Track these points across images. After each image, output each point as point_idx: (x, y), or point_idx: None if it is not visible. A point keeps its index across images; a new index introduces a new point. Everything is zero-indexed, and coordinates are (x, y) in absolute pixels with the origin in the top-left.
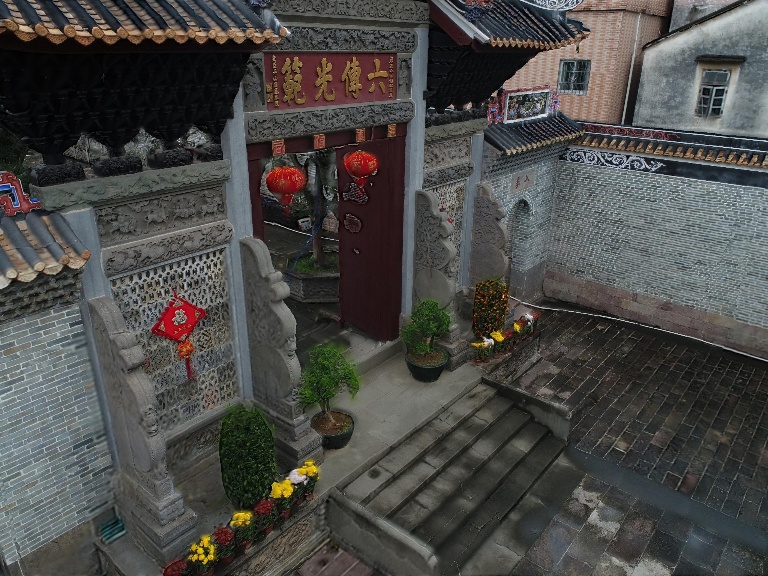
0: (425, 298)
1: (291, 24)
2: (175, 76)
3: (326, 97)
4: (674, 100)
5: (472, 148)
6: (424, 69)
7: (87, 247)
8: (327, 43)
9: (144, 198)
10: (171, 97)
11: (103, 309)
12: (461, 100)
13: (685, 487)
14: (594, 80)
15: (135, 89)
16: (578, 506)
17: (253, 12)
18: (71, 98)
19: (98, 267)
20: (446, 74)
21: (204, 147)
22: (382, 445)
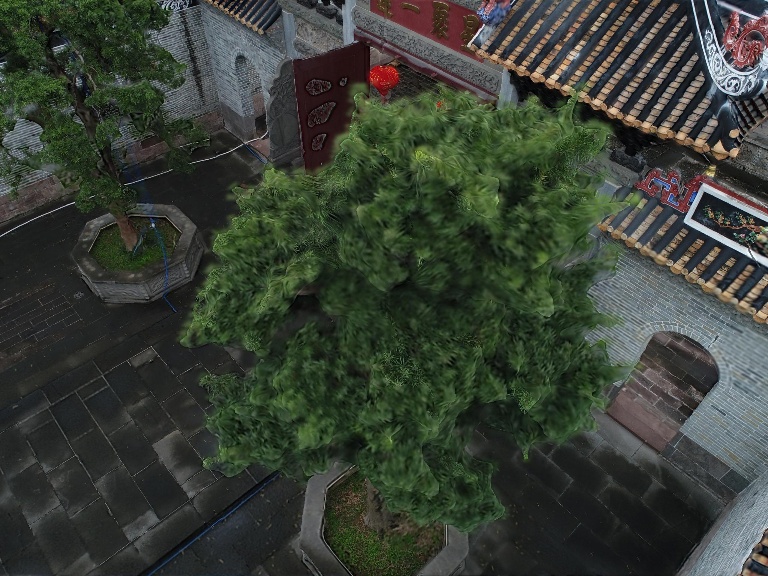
0: None
1: None
2: None
3: None
4: None
5: None
6: None
7: None
8: None
9: None
10: None
11: None
12: None
13: None
14: None
15: None
16: None
17: None
18: None
19: None
20: None
21: None
22: None
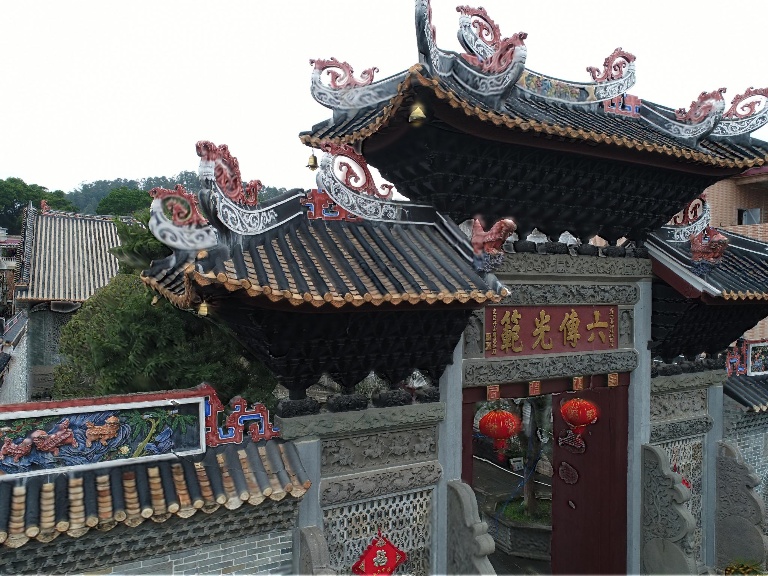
0: (657, 575)
1: (512, 282)
2: (405, 328)
3: (543, 346)
4: None
5: (709, 401)
6: (648, 320)
7: (309, 476)
8: (546, 297)
9: (365, 434)
10: (400, 346)
11: (312, 540)
12: (692, 350)
13: None
14: None
15: (371, 339)
16: None
17: (478, 276)
18: (320, 346)
19: (315, 496)
20: (673, 325)
21: (423, 389)
22: None
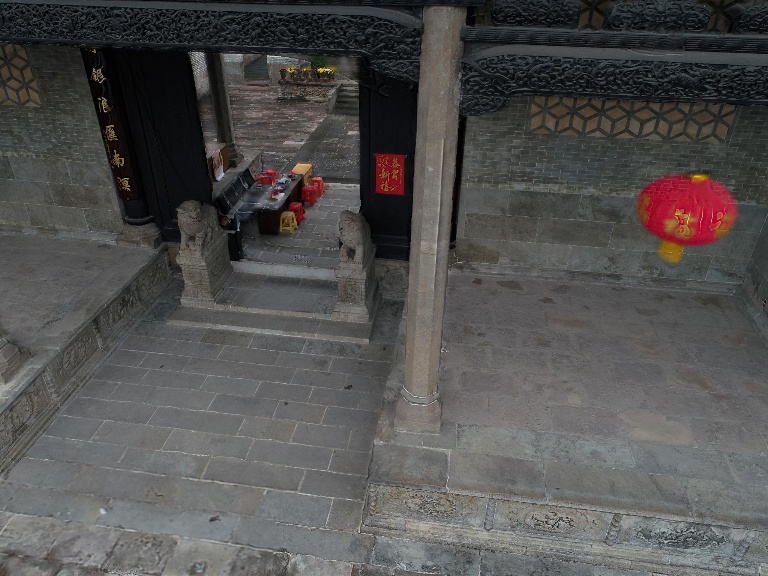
0: None
1: None
2: None
3: None
4: None
5: None
6: None
7: None
8: None
9: None
10: None
11: None
12: None
13: None
14: None
15: None
16: None
17: None
18: None
19: None
20: None
21: None
22: None
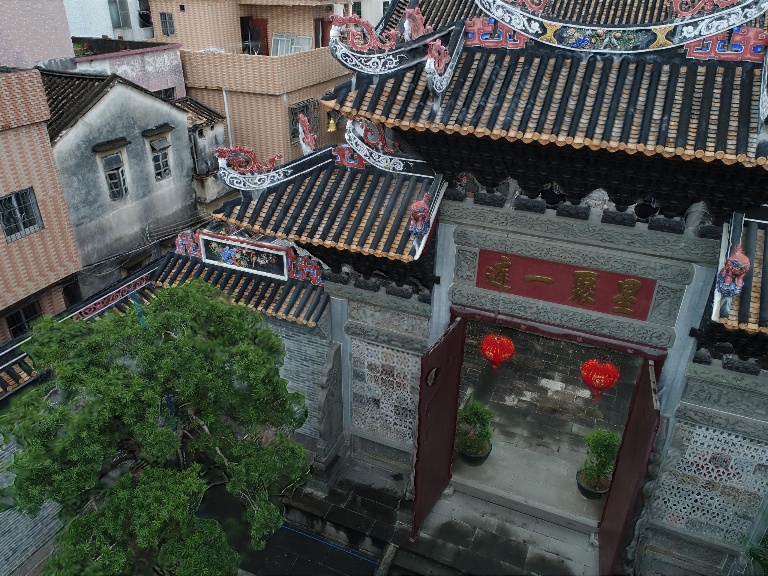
0: None
1: None
2: None
3: None
4: (91, 195)
5: None
6: None
7: None
8: None
9: None
10: None
11: None
12: None
13: (477, 368)
14: (46, 207)
15: None
16: (521, 404)
17: None
18: None
19: None
20: None
21: None
22: (573, 465)
